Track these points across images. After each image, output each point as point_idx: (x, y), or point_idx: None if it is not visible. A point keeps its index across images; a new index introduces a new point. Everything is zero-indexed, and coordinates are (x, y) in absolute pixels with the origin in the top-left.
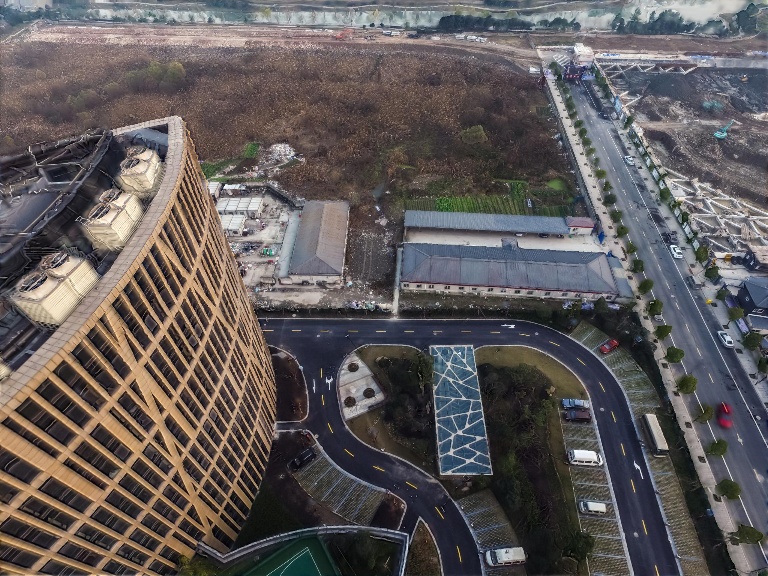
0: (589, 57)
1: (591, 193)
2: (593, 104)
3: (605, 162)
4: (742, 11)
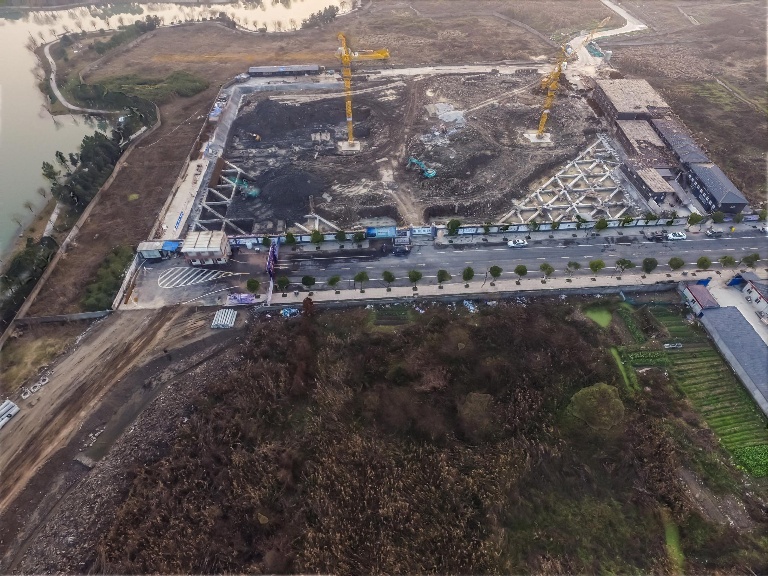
0: (224, 239)
1: (610, 284)
2: (361, 258)
3: (528, 264)
4: (112, 94)
